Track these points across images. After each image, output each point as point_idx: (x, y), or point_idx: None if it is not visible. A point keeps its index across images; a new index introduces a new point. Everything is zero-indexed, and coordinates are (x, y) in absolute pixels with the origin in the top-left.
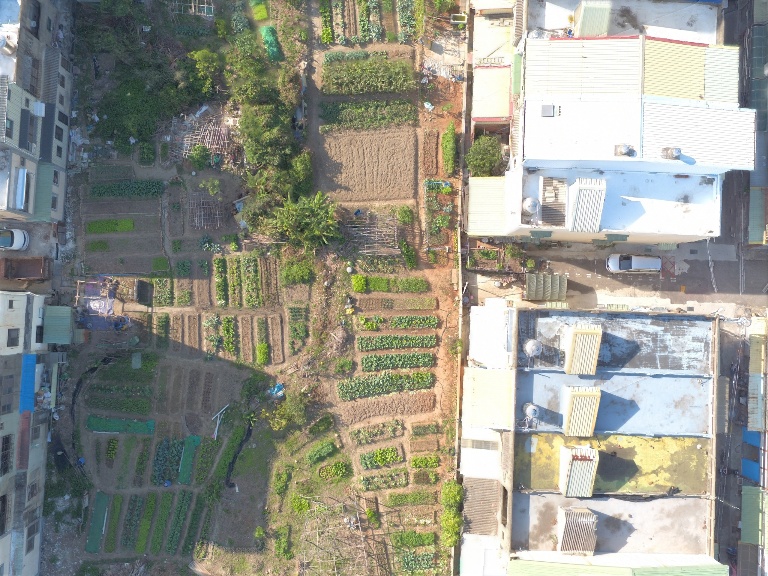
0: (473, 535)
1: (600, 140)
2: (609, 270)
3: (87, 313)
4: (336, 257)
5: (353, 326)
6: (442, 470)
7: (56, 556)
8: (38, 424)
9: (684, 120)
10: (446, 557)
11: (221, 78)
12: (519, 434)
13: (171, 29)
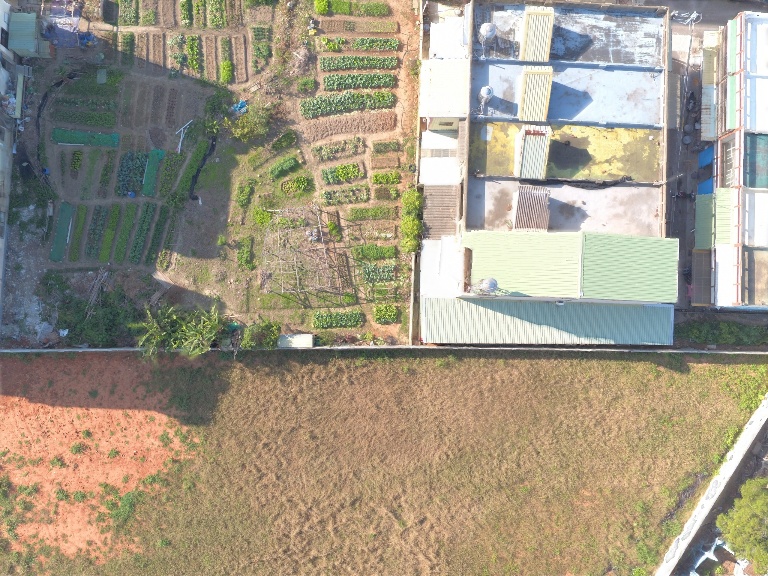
0: (432, 241)
1: None
2: None
3: (53, 30)
4: None
5: (315, 47)
6: (403, 187)
7: (20, 264)
8: (3, 126)
9: None
10: (406, 269)
11: None
12: (475, 122)
13: None
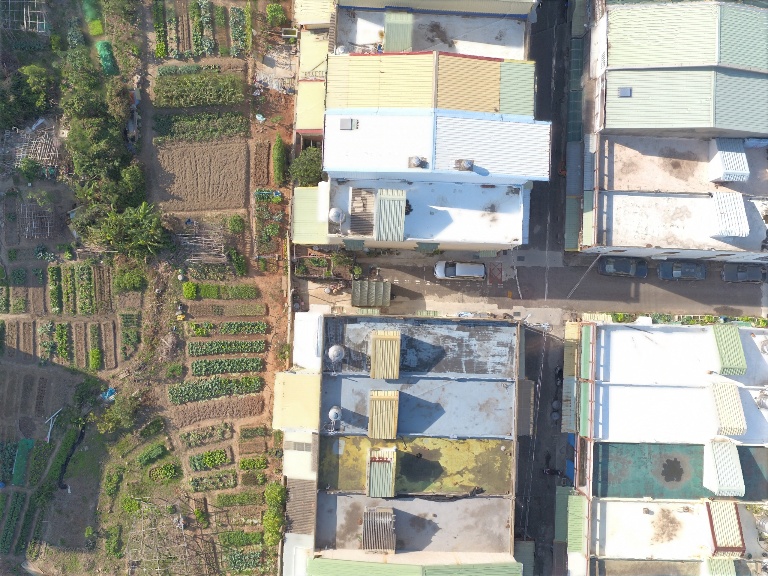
0: (294, 534)
1: (393, 153)
2: (436, 277)
3: None
4: (167, 265)
5: (184, 332)
6: (270, 471)
7: None
8: None
9: (478, 133)
10: (272, 556)
11: (57, 92)
12: (327, 437)
13: (9, 44)
